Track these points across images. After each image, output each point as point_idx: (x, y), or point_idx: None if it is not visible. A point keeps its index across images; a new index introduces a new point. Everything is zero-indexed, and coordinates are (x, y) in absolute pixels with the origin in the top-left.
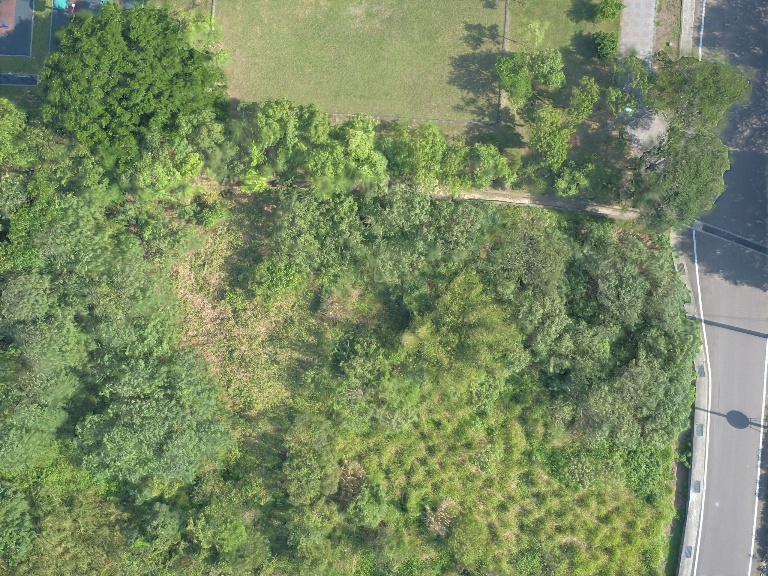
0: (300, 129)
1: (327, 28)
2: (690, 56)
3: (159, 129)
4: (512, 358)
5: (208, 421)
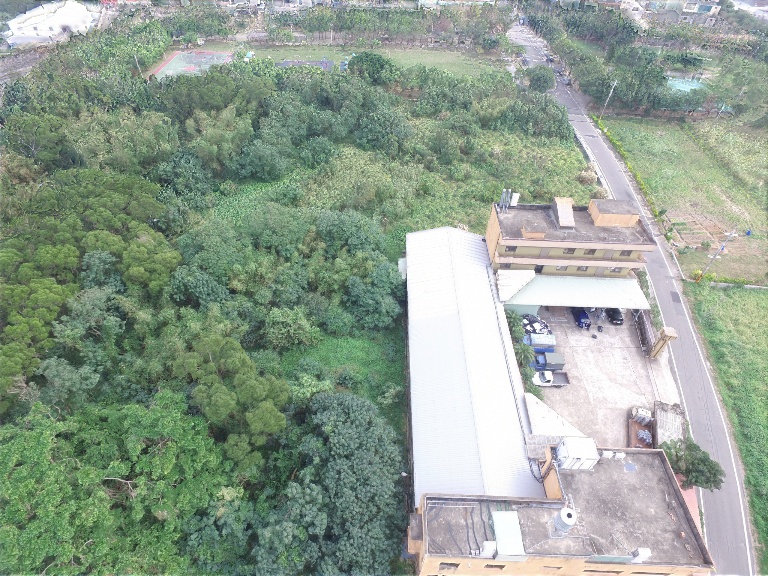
0: None
1: None
2: None
3: None
4: None
5: None
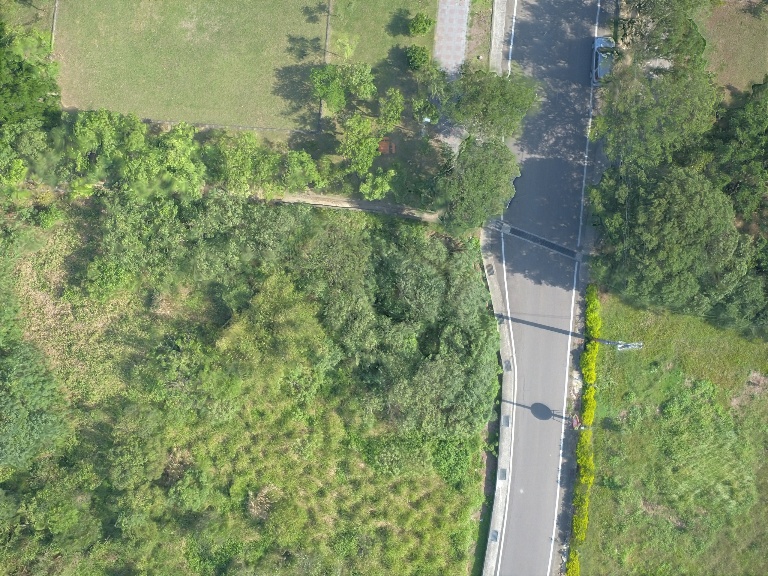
0: (116, 137)
1: (160, 41)
2: (500, 69)
3: None
4: (322, 352)
5: (41, 411)
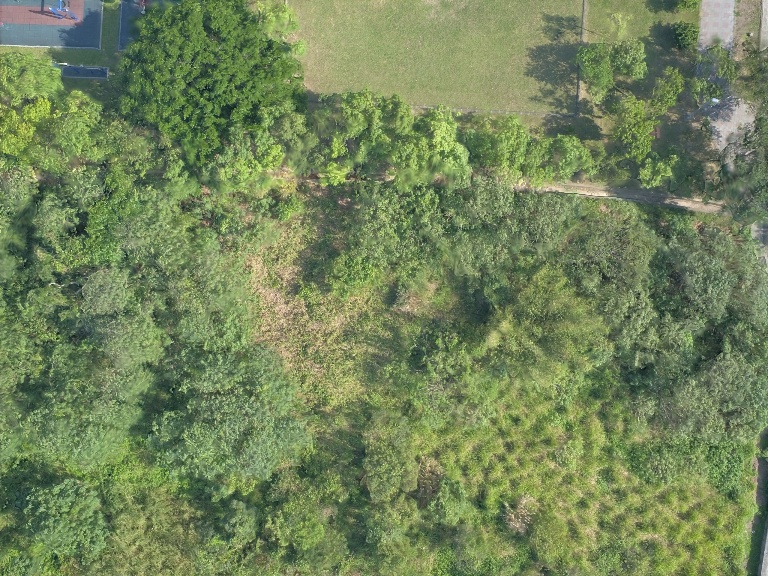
0: (384, 120)
1: (402, 19)
2: None
3: (240, 121)
4: (595, 352)
5: (285, 417)
